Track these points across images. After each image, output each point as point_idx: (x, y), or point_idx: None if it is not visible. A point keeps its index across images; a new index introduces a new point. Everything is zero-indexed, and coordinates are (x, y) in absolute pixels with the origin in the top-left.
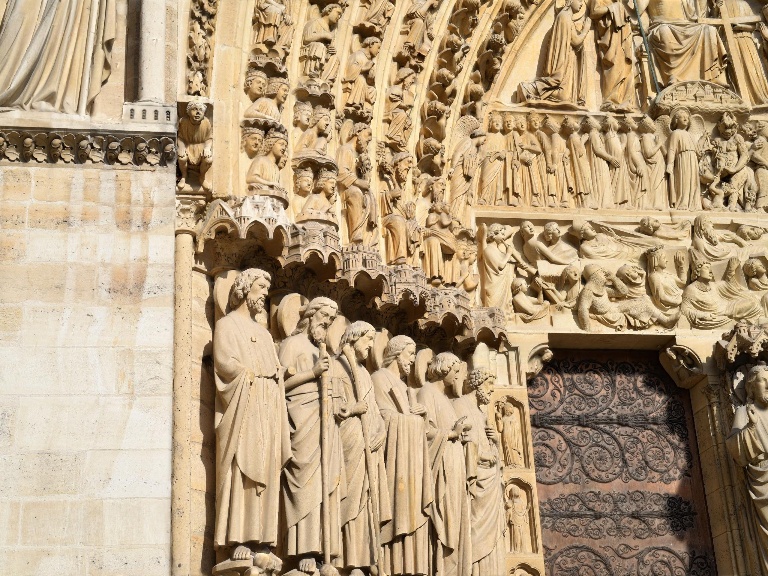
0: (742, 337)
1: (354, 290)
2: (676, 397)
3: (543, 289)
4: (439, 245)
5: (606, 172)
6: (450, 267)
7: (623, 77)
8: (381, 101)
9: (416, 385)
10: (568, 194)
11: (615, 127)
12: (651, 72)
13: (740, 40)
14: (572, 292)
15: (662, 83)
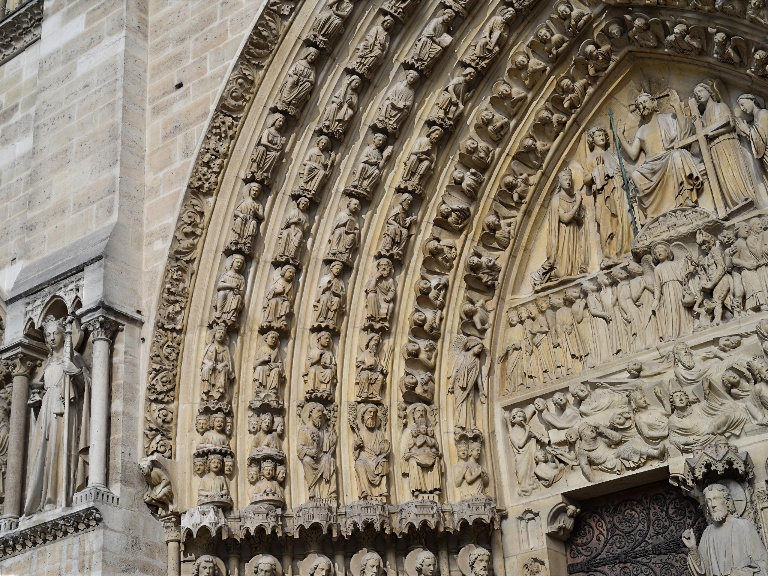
0: None
1: (327, 530)
2: None
3: (554, 455)
4: (415, 464)
5: (602, 329)
6: (432, 476)
7: (609, 234)
8: (353, 369)
9: None
10: (574, 360)
11: (605, 284)
12: None
13: (717, 147)
14: (576, 451)
15: None
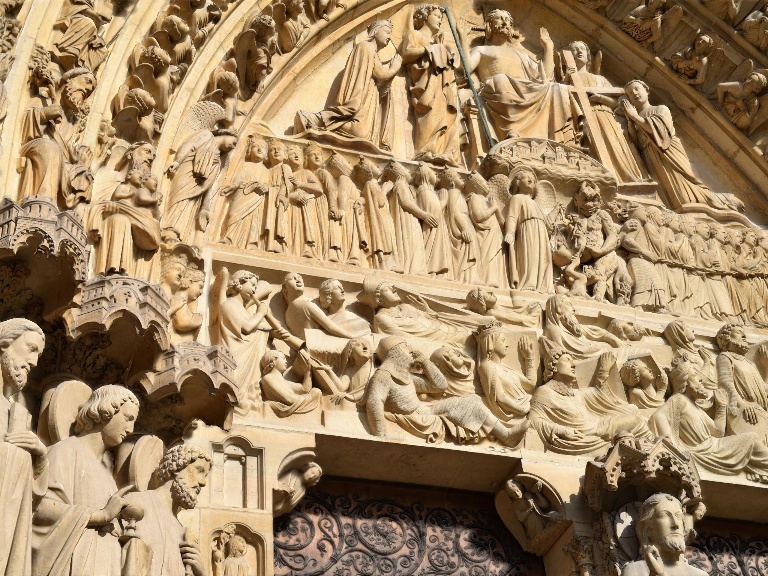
0: (628, 447)
1: None
2: (522, 568)
3: (312, 368)
4: (128, 226)
5: (417, 231)
6: (146, 269)
7: (444, 124)
8: (55, 2)
9: (49, 441)
10: (359, 251)
11: (431, 179)
12: (482, 130)
13: (599, 113)
14: (358, 377)
15: (497, 141)
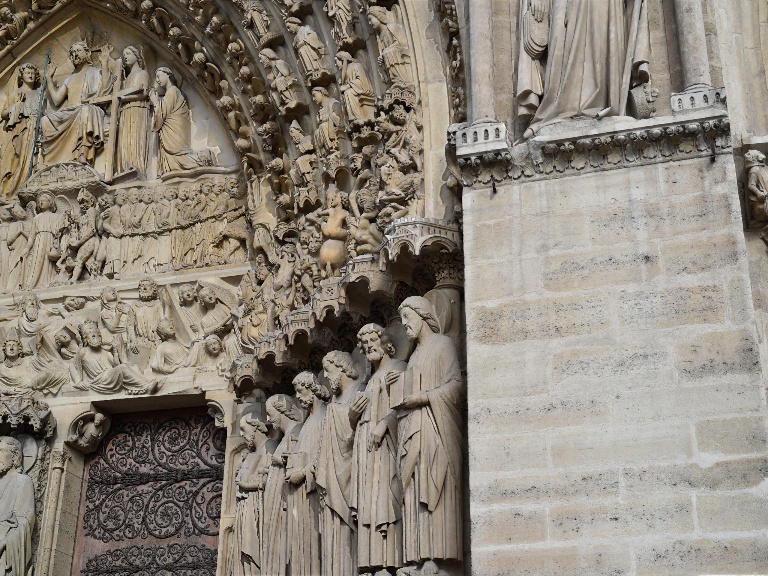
0: None
1: None
2: None
3: None
4: None
5: None
6: None
7: (6, 172)
8: None
9: None
10: None
11: None
12: None
13: (126, 111)
14: None
15: None
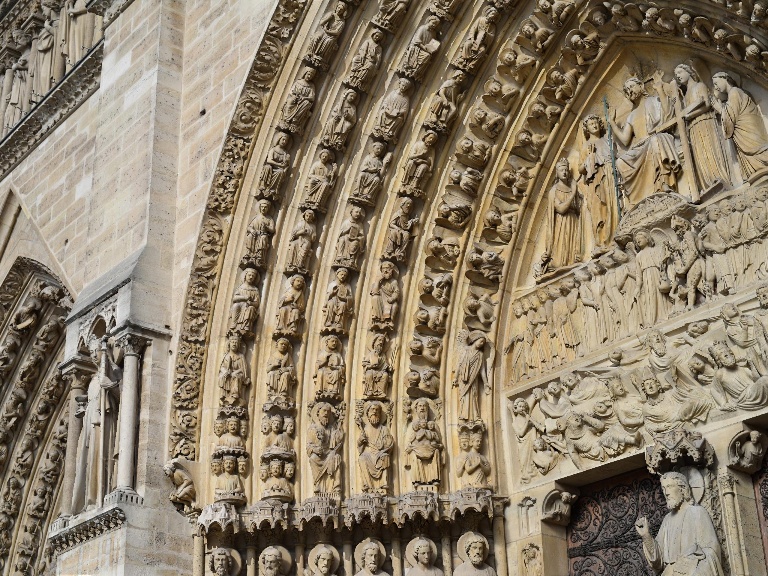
0: None
1: None
2: None
3: (549, 444)
4: (415, 457)
5: (592, 317)
6: None
7: (598, 222)
8: (361, 369)
9: None
10: (568, 350)
11: (595, 273)
12: None
13: (694, 128)
14: None
15: None
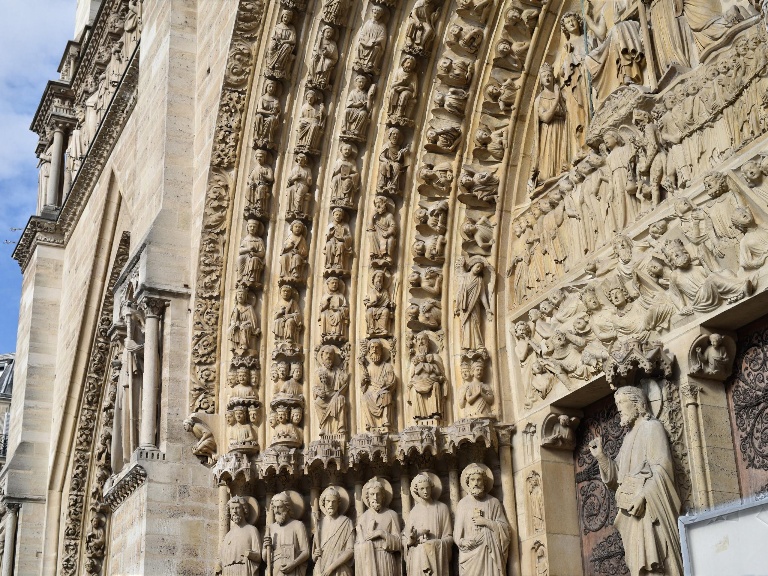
0: None
1: None
2: None
3: None
4: (414, 392)
5: (576, 229)
6: (431, 402)
7: (576, 127)
8: (364, 308)
9: None
10: (558, 266)
11: (575, 181)
12: None
13: (653, 11)
14: None
15: None
